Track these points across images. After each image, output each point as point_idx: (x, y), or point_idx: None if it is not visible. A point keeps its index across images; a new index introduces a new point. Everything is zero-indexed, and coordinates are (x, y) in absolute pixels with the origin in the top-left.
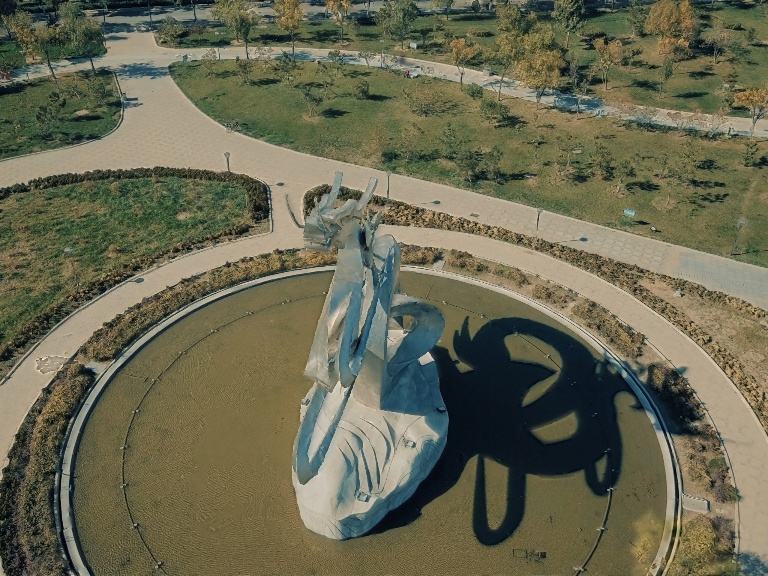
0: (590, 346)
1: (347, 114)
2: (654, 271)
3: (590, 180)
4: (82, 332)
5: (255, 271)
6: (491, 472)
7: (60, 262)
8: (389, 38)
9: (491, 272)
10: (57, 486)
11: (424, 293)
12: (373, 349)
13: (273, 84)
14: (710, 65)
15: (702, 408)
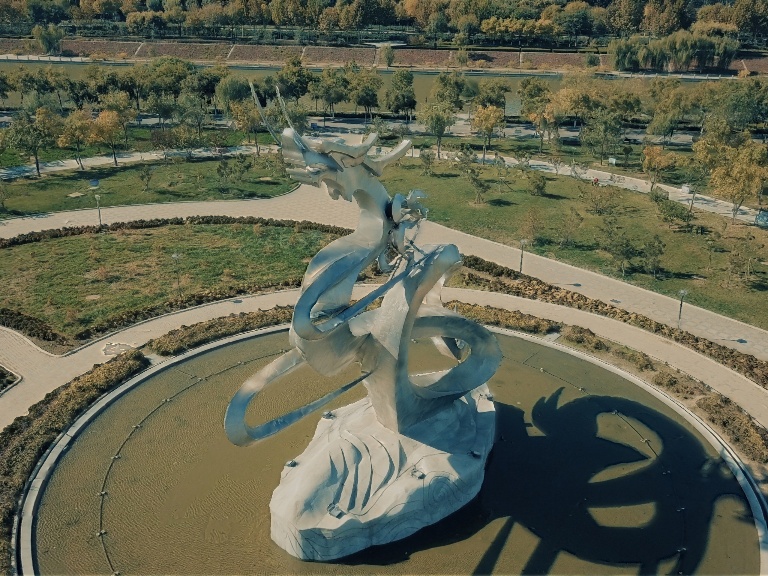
0: (706, 441)
1: (515, 205)
2: None
3: None
4: (161, 330)
5: None
6: (517, 538)
7: (176, 276)
8: (591, 156)
9: (611, 352)
10: (55, 443)
11: (523, 358)
12: (388, 345)
13: (453, 177)
14: None
15: None
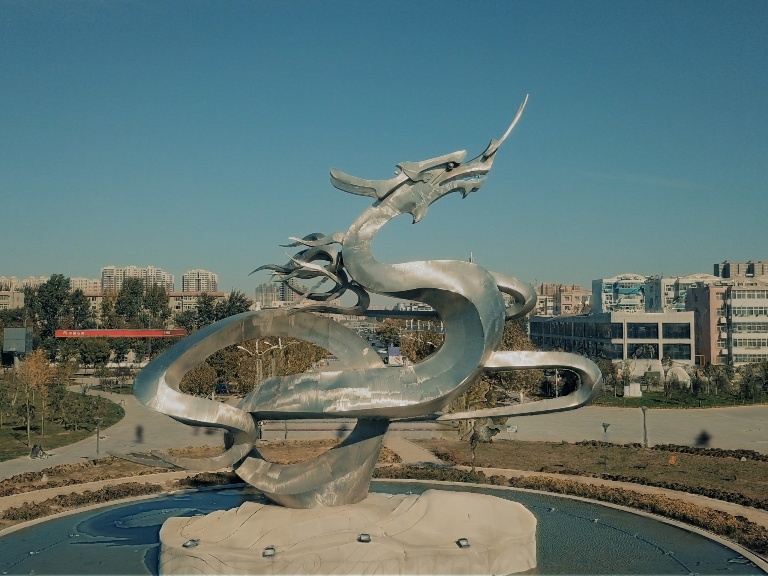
0: (143, 500)
1: None
2: None
3: None
4: None
5: None
6: None
7: None
8: None
9: None
10: None
11: None
12: None
13: None
14: None
15: None
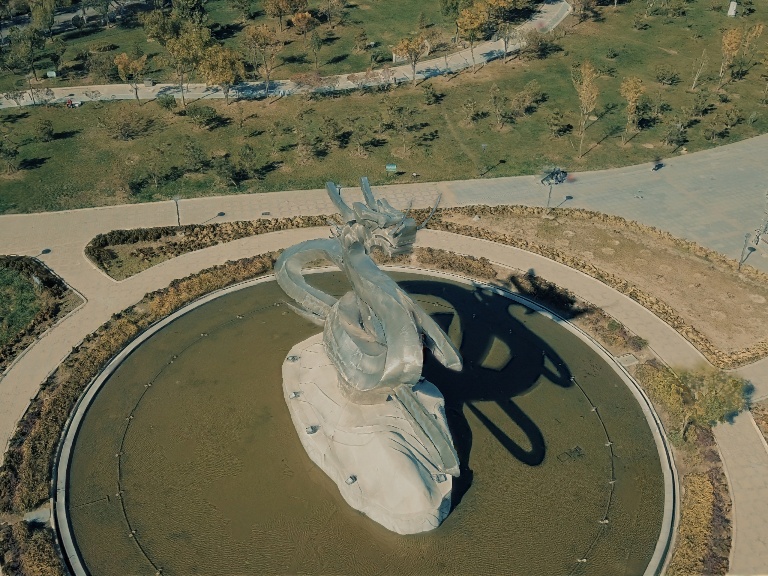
0: (457, 283)
1: (48, 160)
2: (444, 207)
3: (330, 152)
4: None
5: (115, 344)
6: (486, 411)
7: None
8: (11, 73)
9: None
10: None
11: None
12: None
13: None
14: (329, 31)
15: (570, 293)
